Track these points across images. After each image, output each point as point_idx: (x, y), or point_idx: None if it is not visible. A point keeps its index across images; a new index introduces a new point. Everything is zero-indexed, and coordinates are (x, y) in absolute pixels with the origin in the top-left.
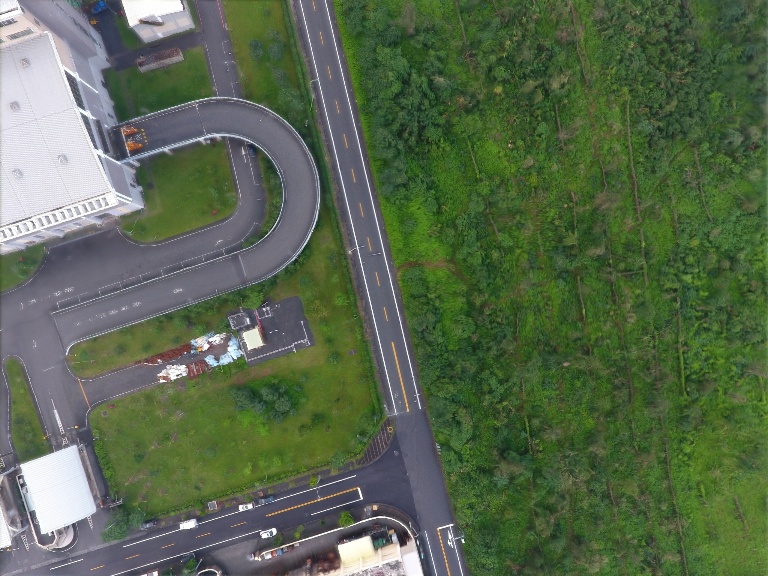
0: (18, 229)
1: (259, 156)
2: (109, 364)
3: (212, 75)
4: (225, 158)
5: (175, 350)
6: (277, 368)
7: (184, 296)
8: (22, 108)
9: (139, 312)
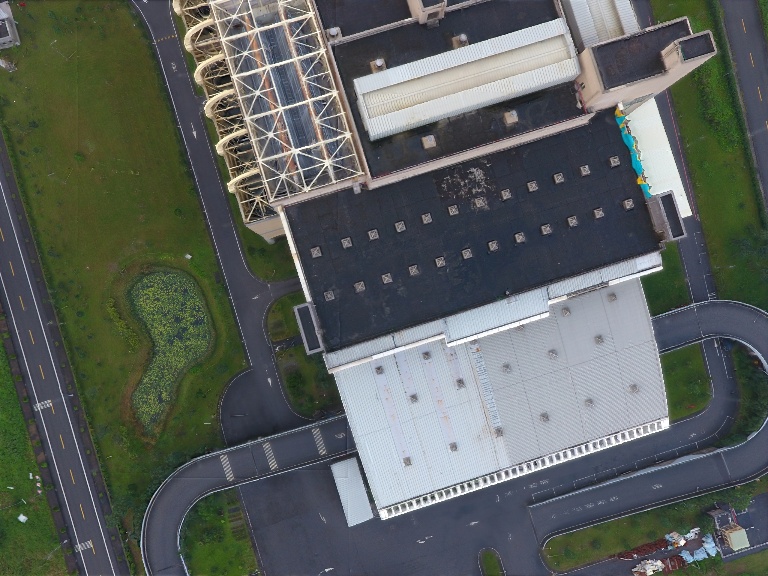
0: (571, 451)
1: (732, 349)
2: (583, 558)
3: (684, 266)
4: (698, 351)
5: (650, 545)
6: (751, 565)
7: (664, 492)
8: (604, 341)
9: (616, 507)
